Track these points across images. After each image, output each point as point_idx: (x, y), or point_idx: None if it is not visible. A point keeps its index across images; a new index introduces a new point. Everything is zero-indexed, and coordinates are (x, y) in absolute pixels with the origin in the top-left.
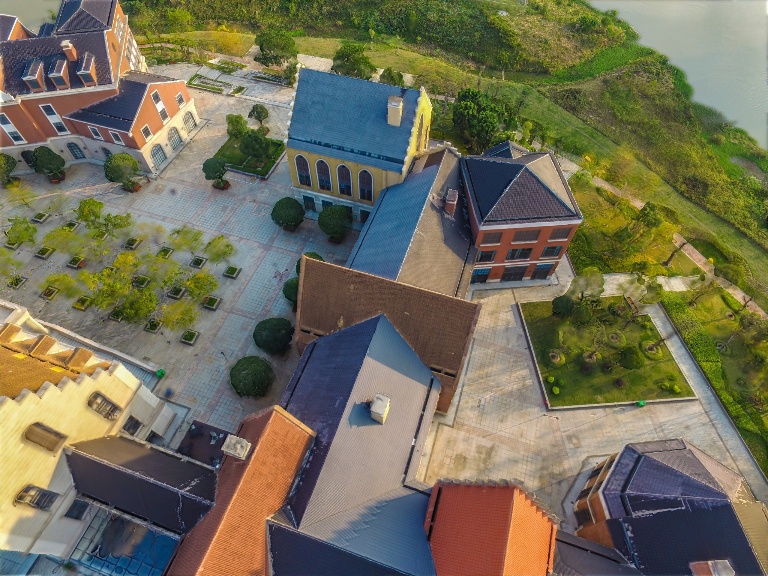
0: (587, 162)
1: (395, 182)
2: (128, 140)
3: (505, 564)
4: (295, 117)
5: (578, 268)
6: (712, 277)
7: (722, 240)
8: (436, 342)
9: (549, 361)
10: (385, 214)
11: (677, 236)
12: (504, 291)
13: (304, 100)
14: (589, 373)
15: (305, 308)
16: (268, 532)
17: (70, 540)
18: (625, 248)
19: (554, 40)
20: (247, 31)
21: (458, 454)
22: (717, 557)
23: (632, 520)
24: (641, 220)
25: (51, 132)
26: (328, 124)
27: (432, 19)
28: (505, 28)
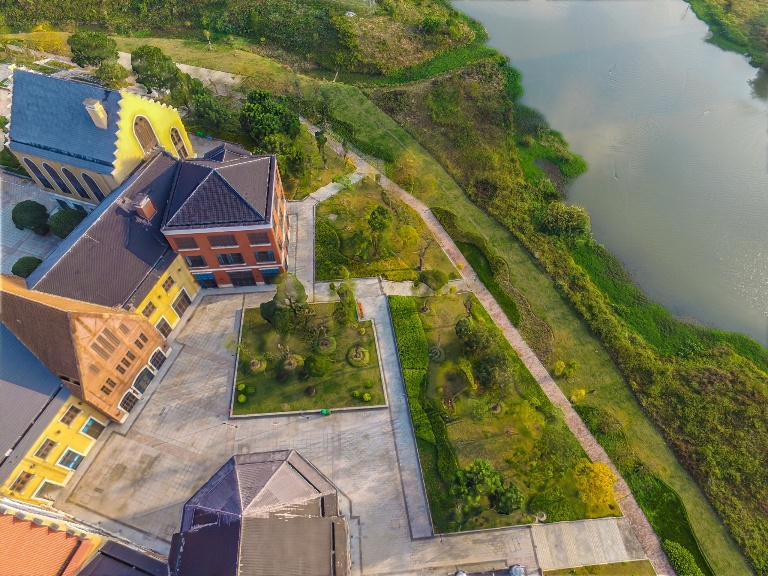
0: (385, 165)
1: (115, 185)
2: None
3: None
4: (14, 119)
5: (318, 273)
6: (467, 282)
7: (492, 244)
8: (52, 350)
9: (248, 368)
10: (88, 218)
11: (448, 240)
12: (235, 296)
13: (20, 102)
14: (285, 380)
15: None
16: None
17: None
18: (358, 253)
19: (394, 41)
20: (93, 32)
21: (119, 464)
22: (217, 575)
23: (187, 535)
24: (370, 224)
25: None
26: (44, 126)
27: (273, 20)
28: (345, 29)
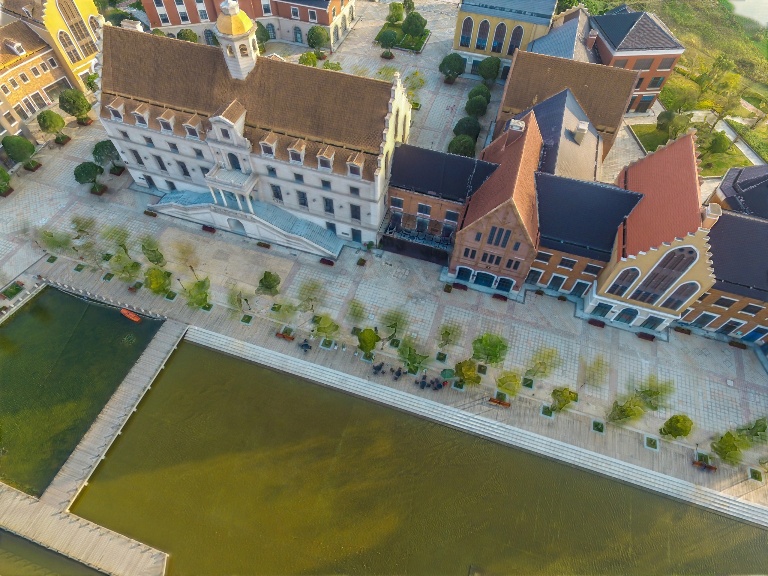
0: None
1: (541, 35)
2: (322, 17)
3: (694, 160)
4: None
5: (668, 106)
6: None
7: (767, 98)
8: (604, 106)
9: None
10: (540, 52)
11: None
12: None
13: None
14: None
15: (510, 91)
16: (535, 178)
17: (380, 219)
18: (704, 88)
19: None
20: None
21: None
22: None
23: (743, 193)
24: (717, 66)
25: (259, 13)
26: None
27: None
28: None
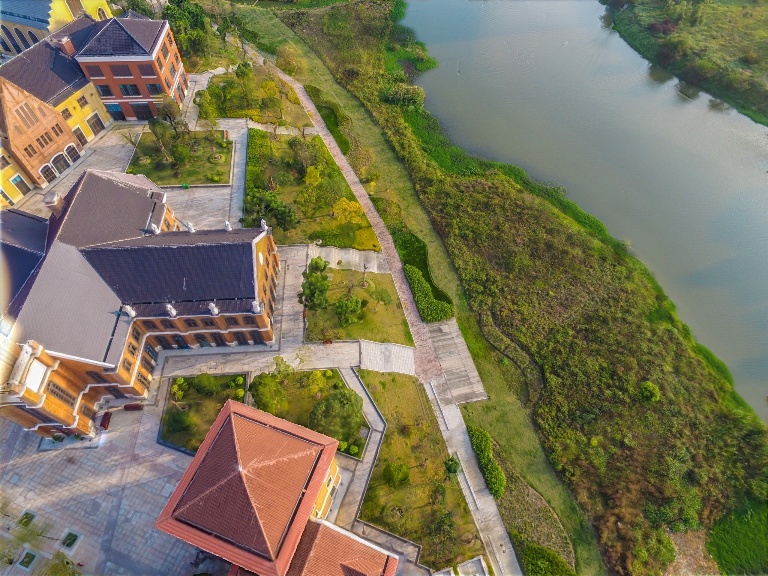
0: (277, 59)
1: None
2: None
3: None
4: None
5: None
6: (317, 129)
7: (344, 108)
8: None
9: (137, 162)
10: None
11: (311, 105)
12: (138, 126)
13: None
14: (161, 169)
15: None
16: None
17: None
18: (229, 96)
19: None
20: None
21: (37, 208)
22: None
23: None
24: None
25: None
26: None
27: None
28: None
